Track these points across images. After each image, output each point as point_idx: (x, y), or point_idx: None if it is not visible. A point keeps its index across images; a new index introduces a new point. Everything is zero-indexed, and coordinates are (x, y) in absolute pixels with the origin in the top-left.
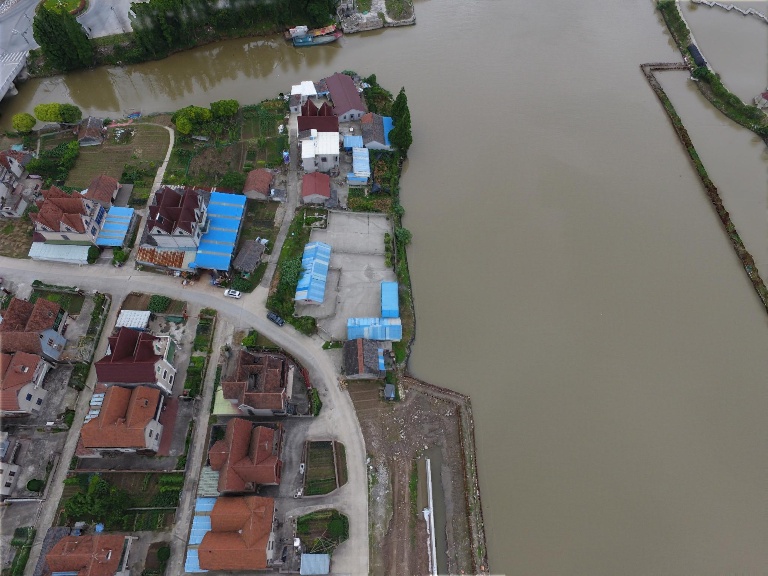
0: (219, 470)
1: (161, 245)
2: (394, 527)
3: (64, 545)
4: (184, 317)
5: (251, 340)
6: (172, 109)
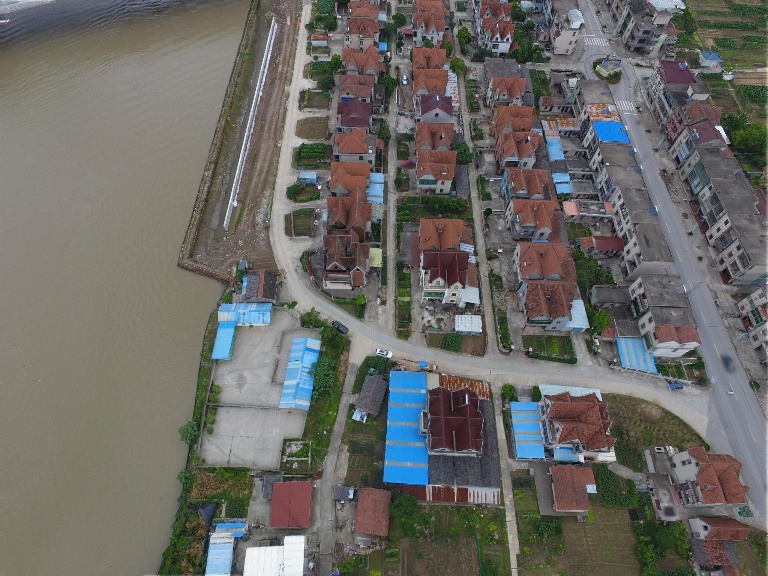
0: None
1: None
2: (258, 196)
3: (449, 172)
4: None
5: (358, 300)
6: None
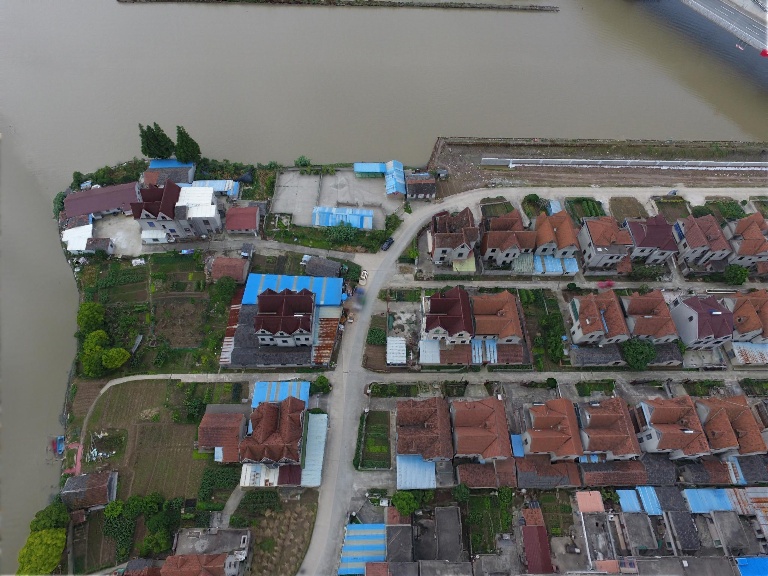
0: (521, 247)
1: (312, 339)
2: None
3: (591, 325)
4: (389, 313)
5: (413, 252)
6: (59, 397)
